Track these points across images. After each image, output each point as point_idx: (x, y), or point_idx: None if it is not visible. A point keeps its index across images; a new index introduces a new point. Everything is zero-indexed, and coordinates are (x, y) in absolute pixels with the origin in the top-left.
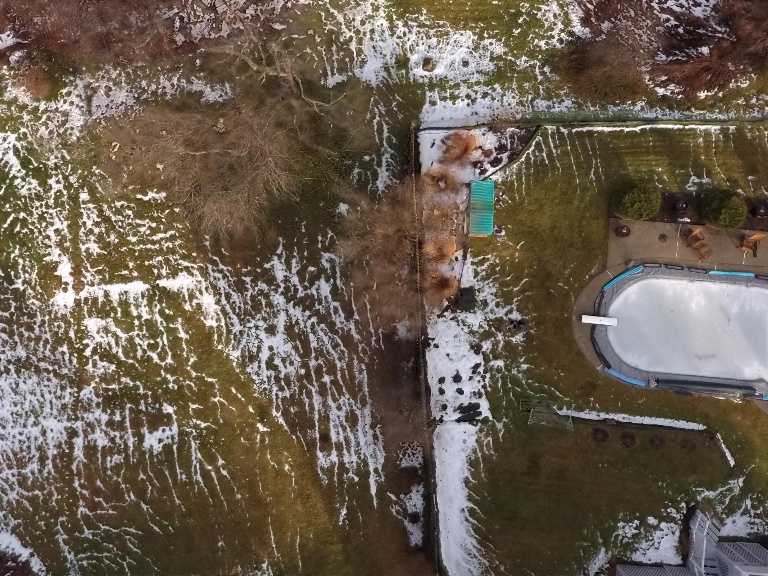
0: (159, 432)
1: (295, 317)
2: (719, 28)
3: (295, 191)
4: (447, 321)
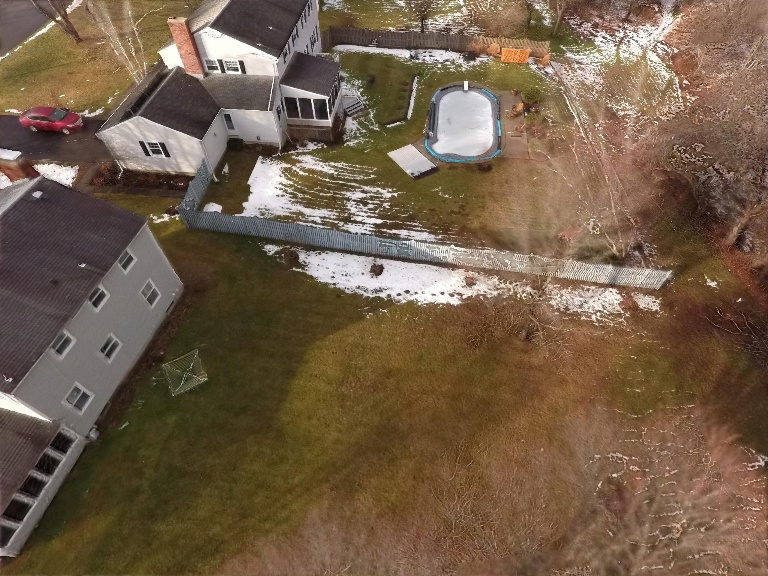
0: (403, 3)
1: (454, 30)
2: None
3: (511, 12)
4: (458, 56)
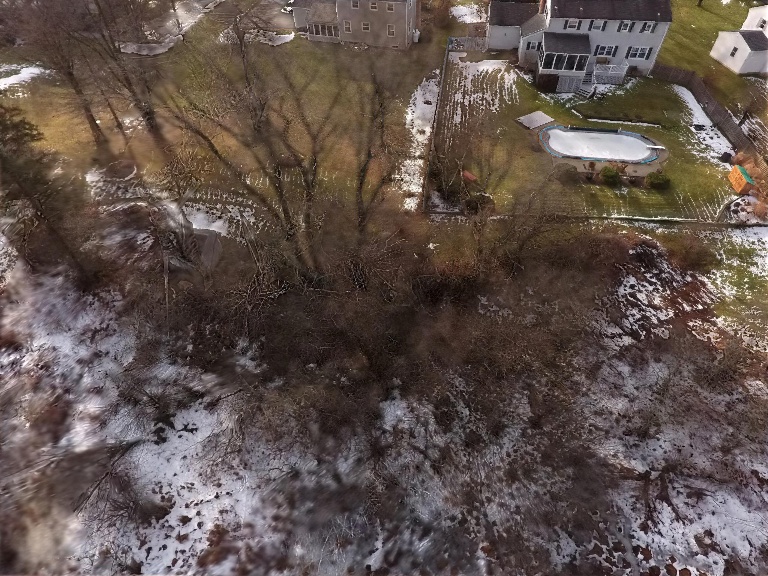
0: None
1: None
2: (620, 267)
3: None
4: None
